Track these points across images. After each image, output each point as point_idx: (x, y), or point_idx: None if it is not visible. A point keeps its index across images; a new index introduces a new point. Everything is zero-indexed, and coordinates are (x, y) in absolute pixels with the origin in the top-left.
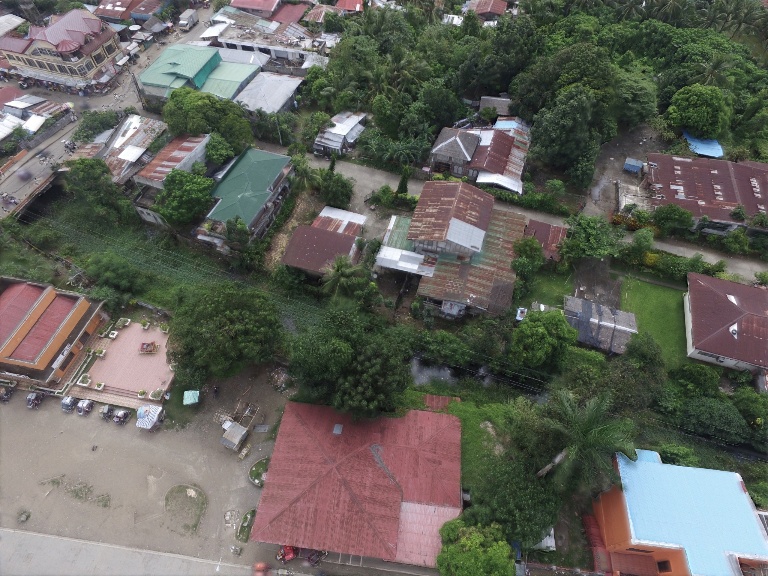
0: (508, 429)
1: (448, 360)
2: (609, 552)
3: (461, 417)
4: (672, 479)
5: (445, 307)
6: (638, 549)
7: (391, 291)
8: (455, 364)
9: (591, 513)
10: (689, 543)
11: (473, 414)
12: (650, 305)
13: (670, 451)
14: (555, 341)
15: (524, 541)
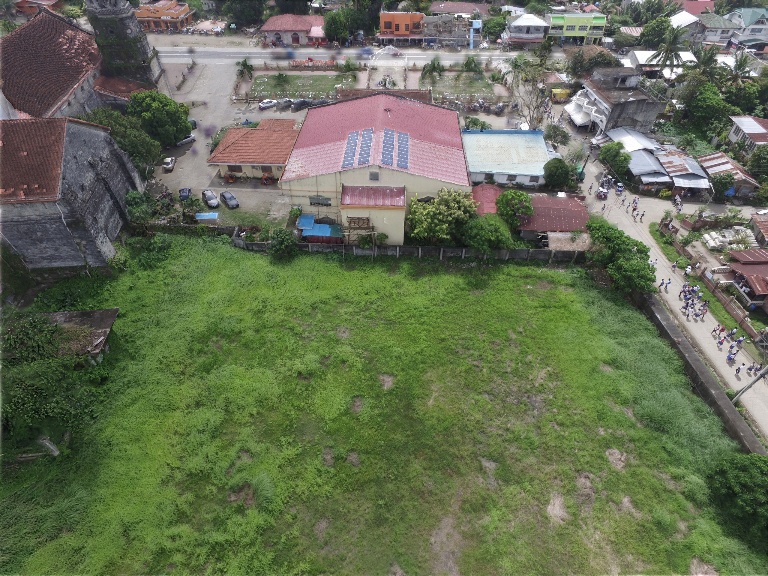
0: None
1: None
2: None
3: None
4: None
5: None
6: (387, 26)
7: None
8: None
9: None
10: None
11: None
12: None
13: None
14: None
15: None
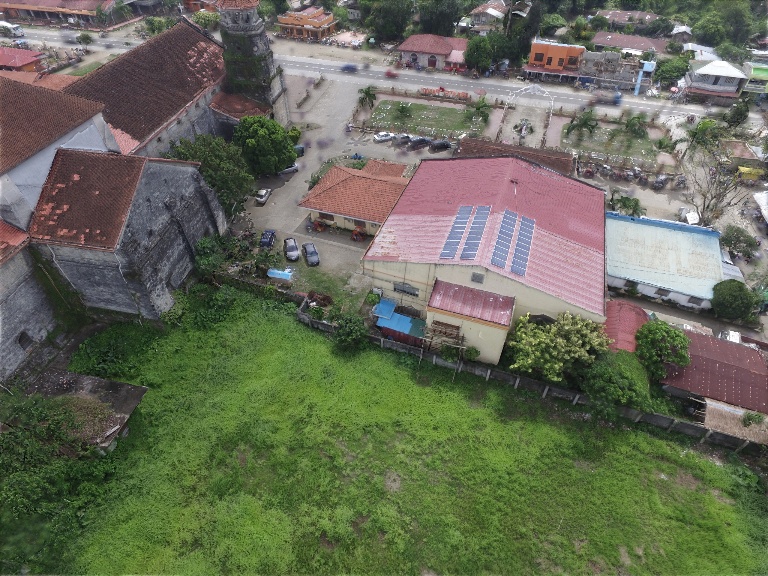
0: None
1: None
2: None
3: None
4: None
5: (481, 33)
6: (538, 58)
7: None
8: None
9: None
10: None
11: None
12: None
13: None
14: None
15: None
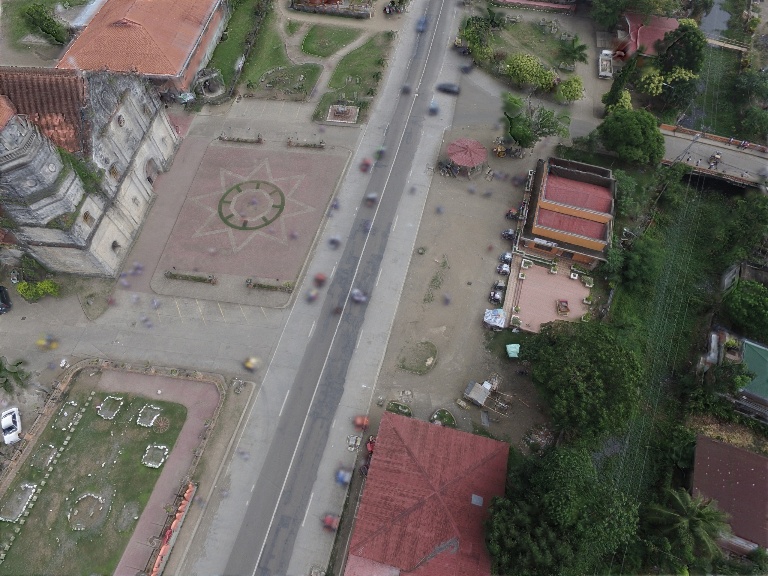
0: None
1: None
2: None
3: None
4: None
5: None
6: None
7: None
8: None
9: None
10: None
11: None
12: None
13: None
14: None
15: None
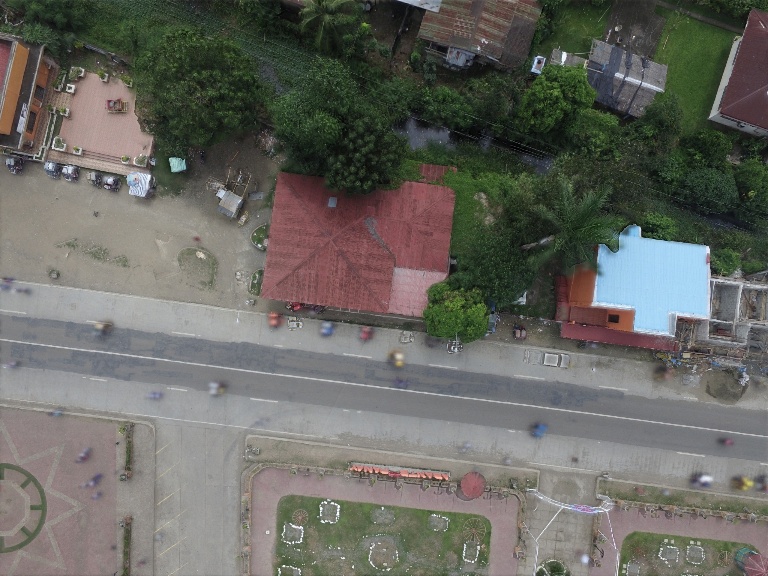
0: (501, 200)
1: (448, 122)
2: (570, 306)
3: (456, 189)
4: (645, 251)
5: (451, 56)
6: None
7: (387, 29)
8: (456, 126)
9: (563, 274)
10: (641, 305)
11: (468, 186)
12: (690, 52)
13: (653, 222)
14: (569, 107)
15: (499, 302)
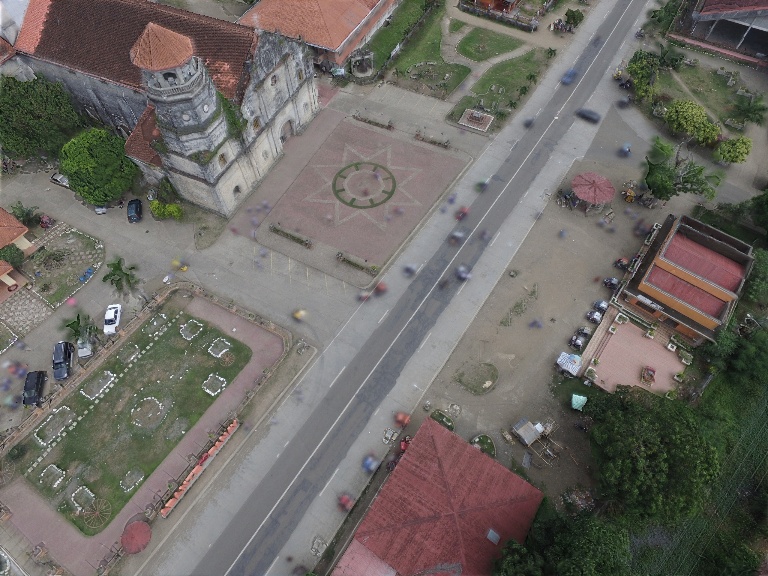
0: None
1: None
2: None
3: None
4: None
5: None
6: None
7: None
8: None
9: None
10: None
11: None
12: None
13: None
14: None
15: None
